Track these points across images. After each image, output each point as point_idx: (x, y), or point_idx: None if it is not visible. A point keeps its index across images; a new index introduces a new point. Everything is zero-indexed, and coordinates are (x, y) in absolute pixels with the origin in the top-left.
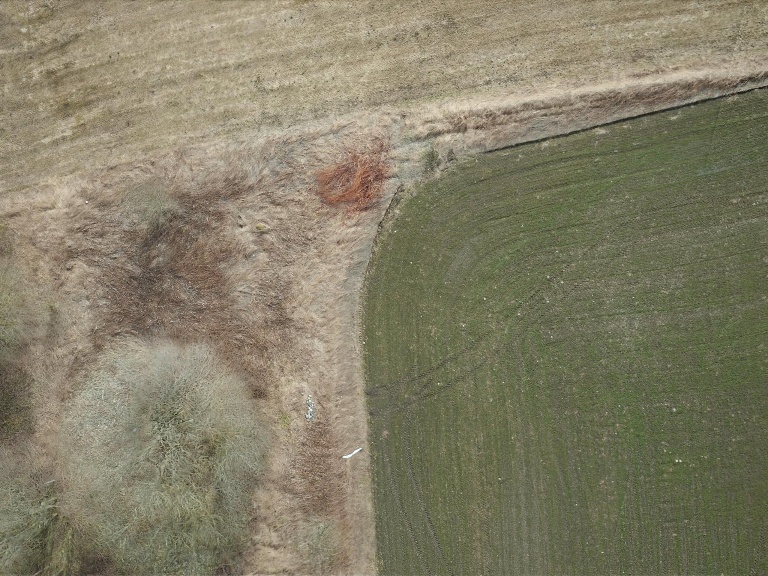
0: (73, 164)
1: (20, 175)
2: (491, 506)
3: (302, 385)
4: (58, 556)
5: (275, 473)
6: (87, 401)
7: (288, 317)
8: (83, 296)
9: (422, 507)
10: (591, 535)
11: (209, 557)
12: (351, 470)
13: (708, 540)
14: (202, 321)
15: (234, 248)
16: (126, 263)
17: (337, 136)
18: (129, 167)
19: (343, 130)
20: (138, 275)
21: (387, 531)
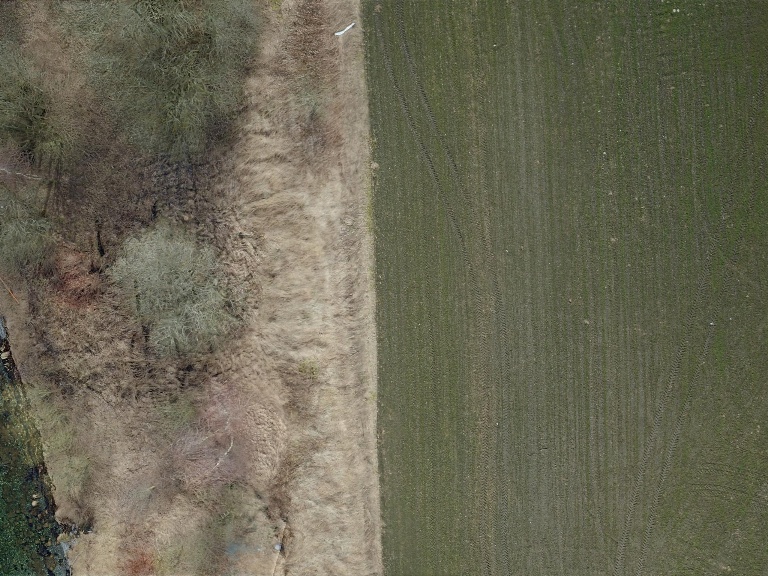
0: None
1: None
2: (486, 74)
3: None
4: (46, 145)
5: (266, 56)
6: (75, 6)
7: None
8: None
9: (416, 80)
10: (587, 94)
11: (200, 156)
12: (343, 47)
13: (706, 91)
14: None
15: None
16: None
17: None
18: None
19: None
20: None
21: (380, 107)
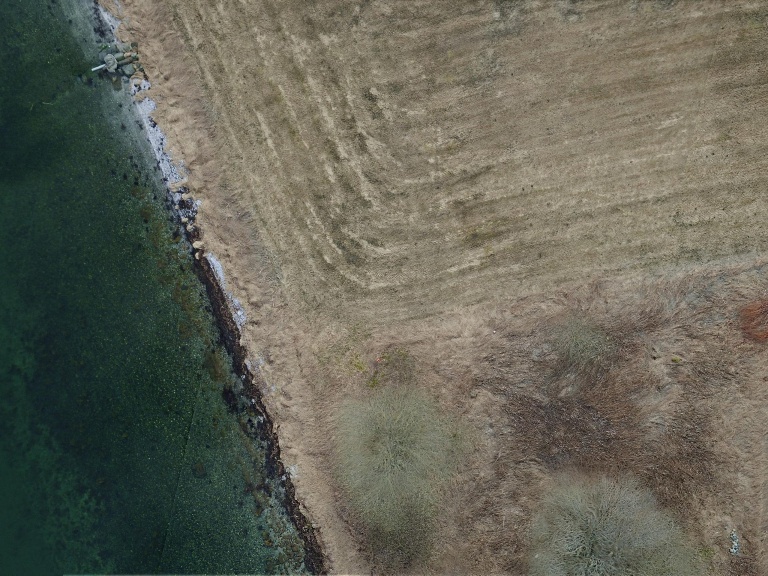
0: (480, 294)
1: (423, 303)
2: None
3: (725, 519)
4: None
5: None
6: (487, 527)
7: (707, 450)
8: (486, 423)
9: None
10: None
11: None
12: None
13: None
14: (610, 450)
15: (647, 379)
16: (534, 392)
17: (760, 272)
18: (541, 298)
19: (767, 266)
20: (546, 404)
21: None
